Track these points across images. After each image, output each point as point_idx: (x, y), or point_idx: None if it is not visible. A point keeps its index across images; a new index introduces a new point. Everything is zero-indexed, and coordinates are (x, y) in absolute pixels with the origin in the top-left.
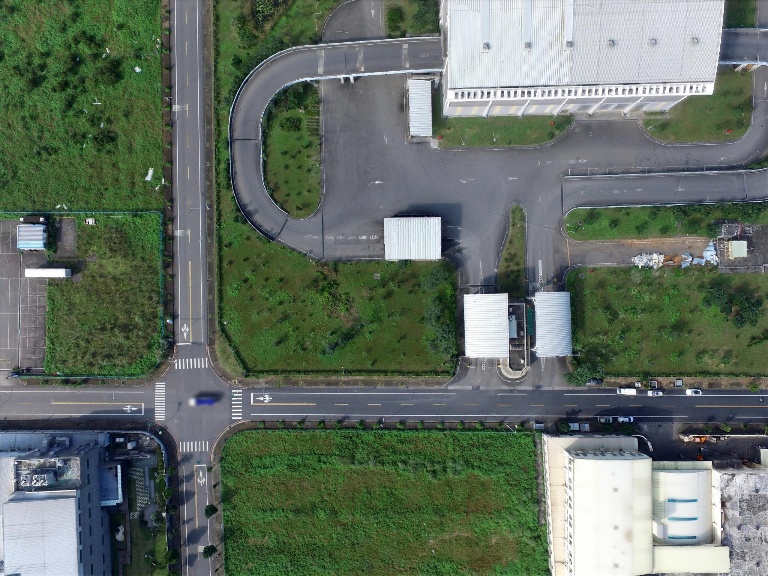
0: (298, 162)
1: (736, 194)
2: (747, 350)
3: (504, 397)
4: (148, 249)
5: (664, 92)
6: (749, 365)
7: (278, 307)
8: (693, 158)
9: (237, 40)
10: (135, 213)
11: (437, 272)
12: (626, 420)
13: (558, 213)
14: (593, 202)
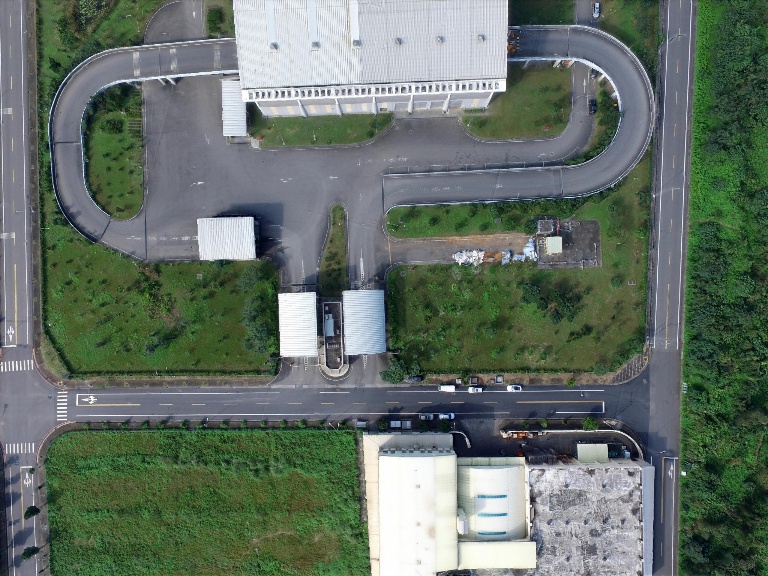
0: (120, 164)
1: (552, 190)
2: (567, 346)
3: (327, 395)
4: None
5: (458, 89)
6: (569, 360)
7: (101, 308)
8: (513, 155)
9: (60, 43)
10: None
11: (250, 272)
12: (446, 417)
13: (379, 211)
14: (413, 200)
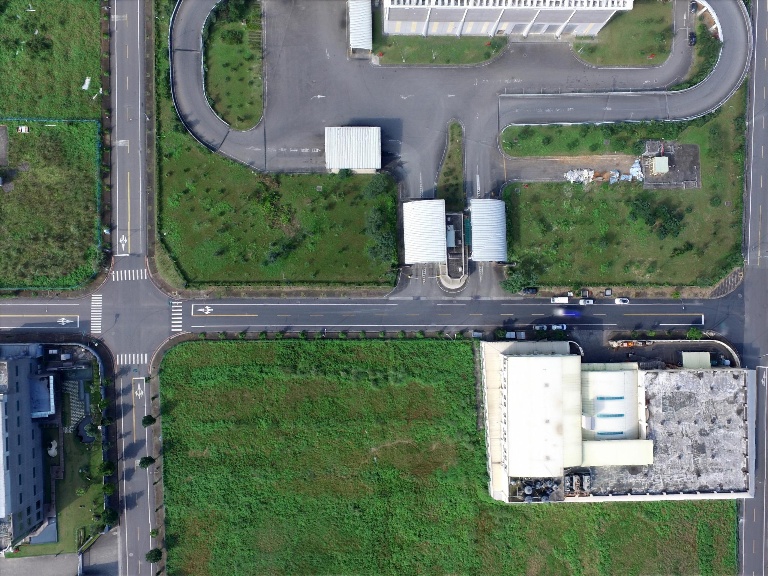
0: (240, 74)
1: (659, 114)
2: (670, 261)
3: (444, 307)
4: (84, 159)
5: (588, 5)
6: (672, 275)
7: (219, 218)
8: (620, 81)
9: None
10: (71, 121)
11: (377, 180)
12: (559, 327)
13: (495, 130)
14: (528, 120)
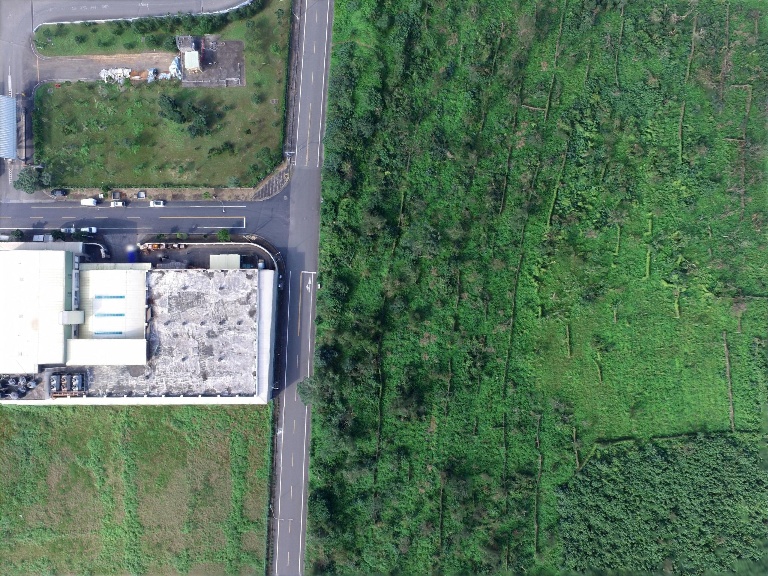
0: None
1: (193, 8)
2: (209, 162)
3: None
4: None
5: None
6: (211, 177)
7: None
8: None
9: None
10: None
11: None
12: (86, 230)
13: (28, 30)
14: (62, 18)
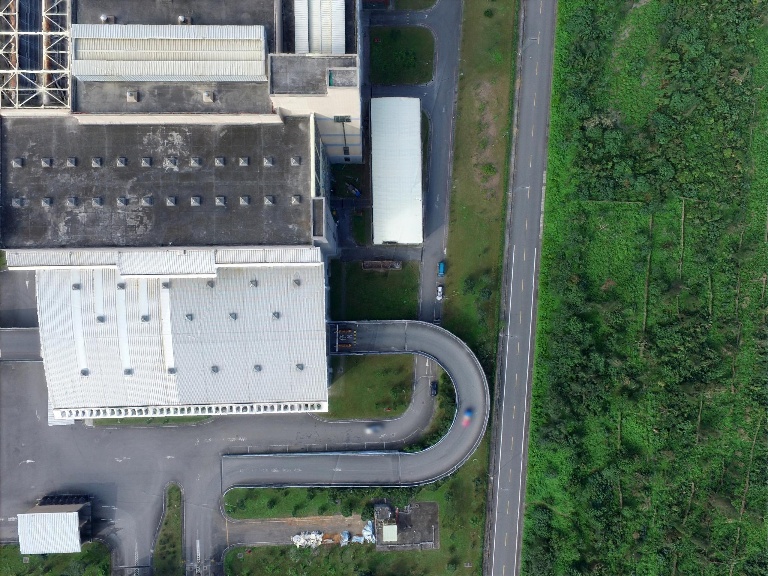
0: None
1: (390, 476)
2: None
3: None
4: None
5: (280, 409)
6: None
7: None
8: (354, 435)
9: None
10: None
11: (73, 569)
12: None
13: (217, 491)
14: (252, 481)
